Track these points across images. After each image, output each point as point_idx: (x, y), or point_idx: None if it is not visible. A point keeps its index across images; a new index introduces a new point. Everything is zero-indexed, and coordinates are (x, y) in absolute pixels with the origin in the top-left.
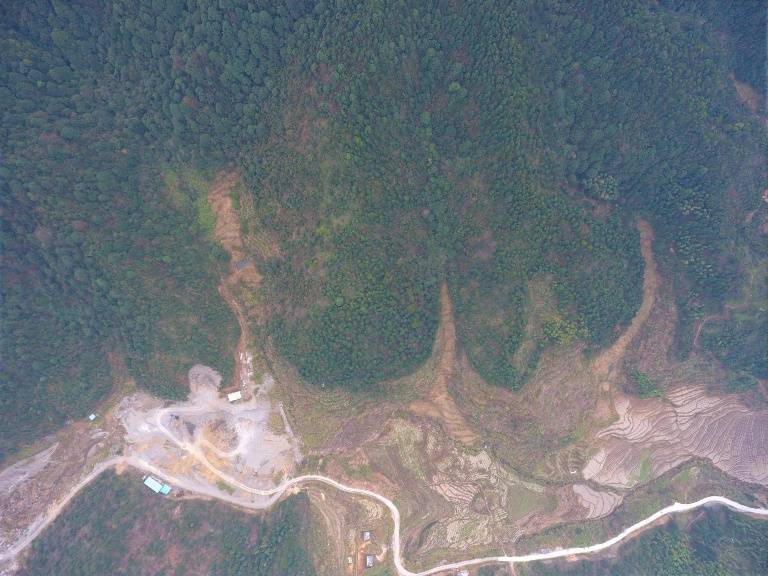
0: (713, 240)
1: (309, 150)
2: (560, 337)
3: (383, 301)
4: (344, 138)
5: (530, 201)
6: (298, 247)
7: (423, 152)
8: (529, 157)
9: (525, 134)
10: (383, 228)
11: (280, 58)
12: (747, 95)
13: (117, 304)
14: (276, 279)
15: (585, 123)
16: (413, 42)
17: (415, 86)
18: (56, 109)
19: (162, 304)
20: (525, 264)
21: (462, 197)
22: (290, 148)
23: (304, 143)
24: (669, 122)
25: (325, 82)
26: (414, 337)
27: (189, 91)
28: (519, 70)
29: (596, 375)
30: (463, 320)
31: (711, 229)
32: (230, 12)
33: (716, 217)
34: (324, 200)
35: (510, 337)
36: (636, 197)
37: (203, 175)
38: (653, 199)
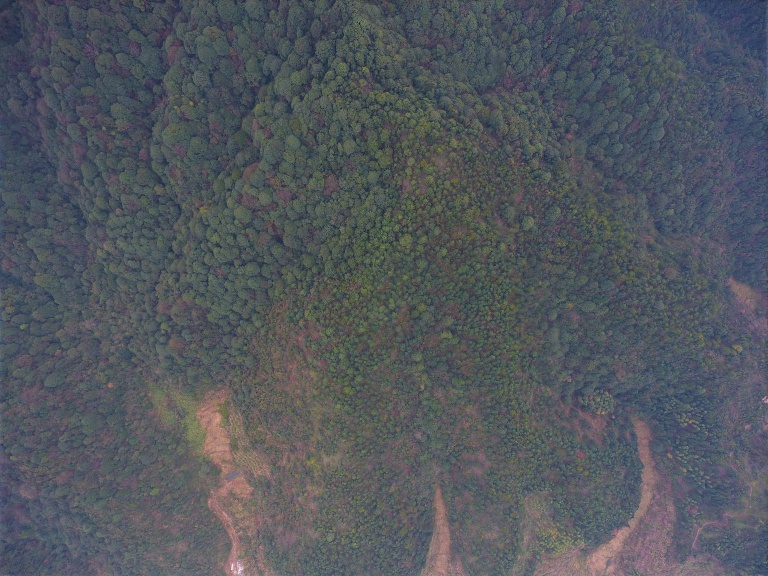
0: (711, 454)
1: (298, 394)
2: (556, 548)
3: (375, 532)
4: (333, 389)
5: (524, 437)
6: (288, 475)
7: (415, 381)
8: (523, 397)
9: (519, 382)
10: (375, 459)
11: (268, 297)
12: (746, 295)
13: (104, 542)
14: (267, 496)
15: (580, 354)
16: (403, 302)
17: (406, 334)
18: (40, 349)
19: (150, 540)
20: (520, 485)
21: (455, 421)
22: (279, 389)
23: (293, 388)
24: (666, 354)
25: (313, 338)
26: (407, 557)
27: (175, 336)
28: (512, 326)
29: (593, 570)
30: (457, 528)
31: (709, 444)
32: (216, 268)
33: (714, 434)
34: (314, 436)
35: (505, 554)
36: (633, 406)
37: (191, 396)
38: (650, 409)
